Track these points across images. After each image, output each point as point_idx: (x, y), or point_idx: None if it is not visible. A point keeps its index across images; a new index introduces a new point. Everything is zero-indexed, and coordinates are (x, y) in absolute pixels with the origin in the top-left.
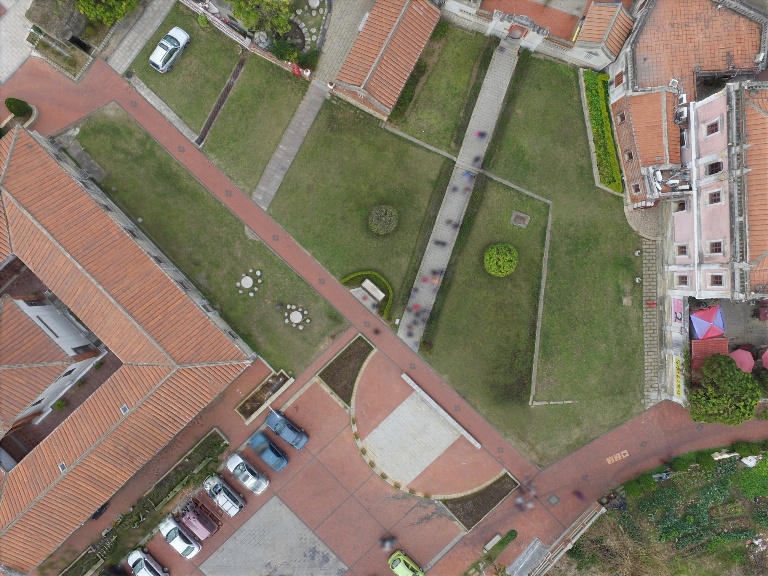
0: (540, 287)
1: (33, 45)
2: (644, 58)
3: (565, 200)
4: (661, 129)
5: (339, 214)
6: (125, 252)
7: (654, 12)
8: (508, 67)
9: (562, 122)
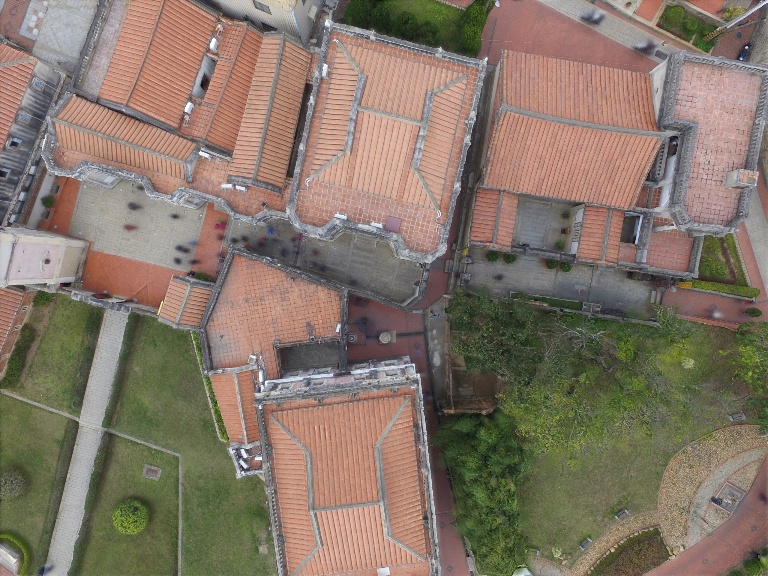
0: (178, 538)
1: None
2: (220, 335)
3: (192, 453)
4: (238, 409)
5: None
6: None
7: (226, 289)
8: (122, 325)
9: (181, 377)
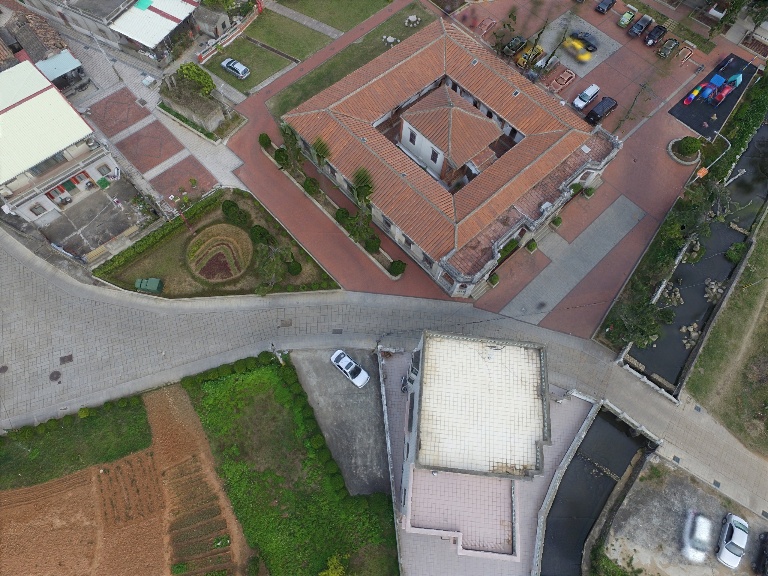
0: None
1: (220, 139)
2: None
3: None
4: None
5: (348, 2)
6: (372, 66)
7: None
8: None
9: None
